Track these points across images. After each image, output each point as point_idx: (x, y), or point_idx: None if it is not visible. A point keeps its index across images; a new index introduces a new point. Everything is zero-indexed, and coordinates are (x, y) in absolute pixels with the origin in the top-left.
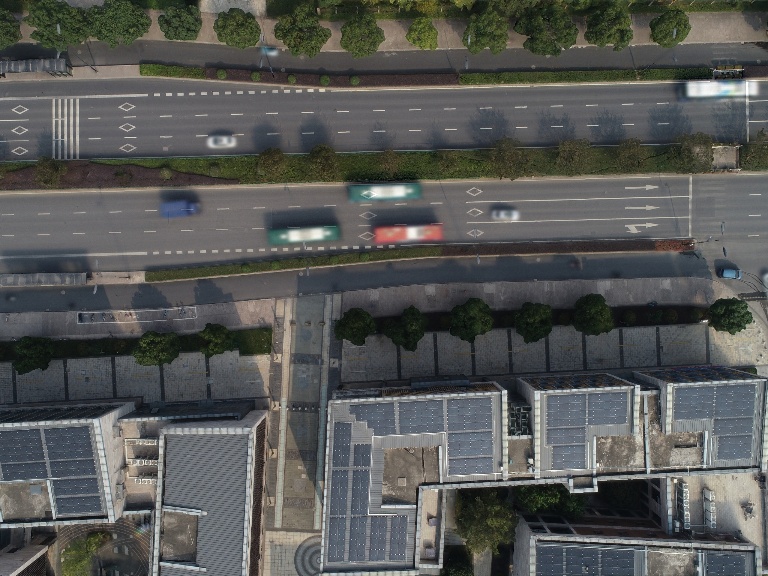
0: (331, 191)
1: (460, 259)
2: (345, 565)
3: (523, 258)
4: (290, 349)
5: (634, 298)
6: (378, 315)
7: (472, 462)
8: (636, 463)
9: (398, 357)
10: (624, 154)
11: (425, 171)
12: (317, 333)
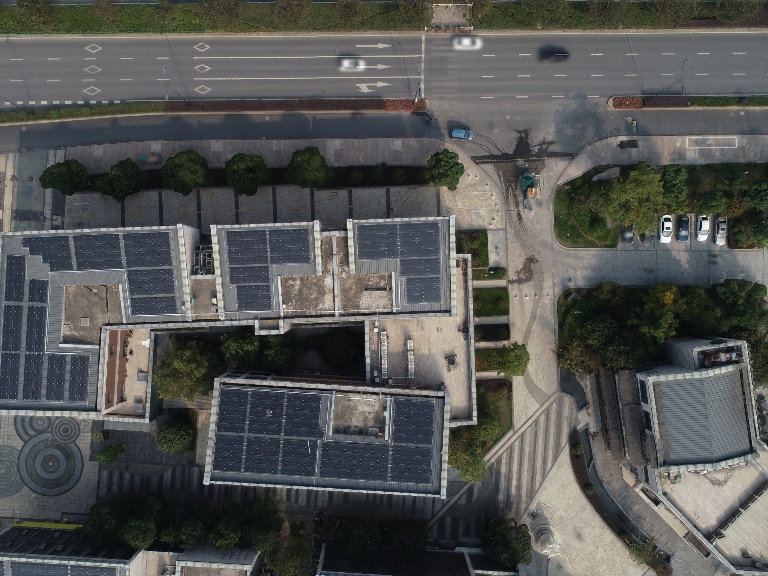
0: (55, 44)
1: (187, 116)
2: (19, 403)
3: (252, 116)
4: (11, 205)
5: (364, 158)
6: (102, 171)
7: (155, 301)
8: (325, 306)
9: (122, 215)
10: (340, 3)
11: (148, 23)
12: (39, 189)
